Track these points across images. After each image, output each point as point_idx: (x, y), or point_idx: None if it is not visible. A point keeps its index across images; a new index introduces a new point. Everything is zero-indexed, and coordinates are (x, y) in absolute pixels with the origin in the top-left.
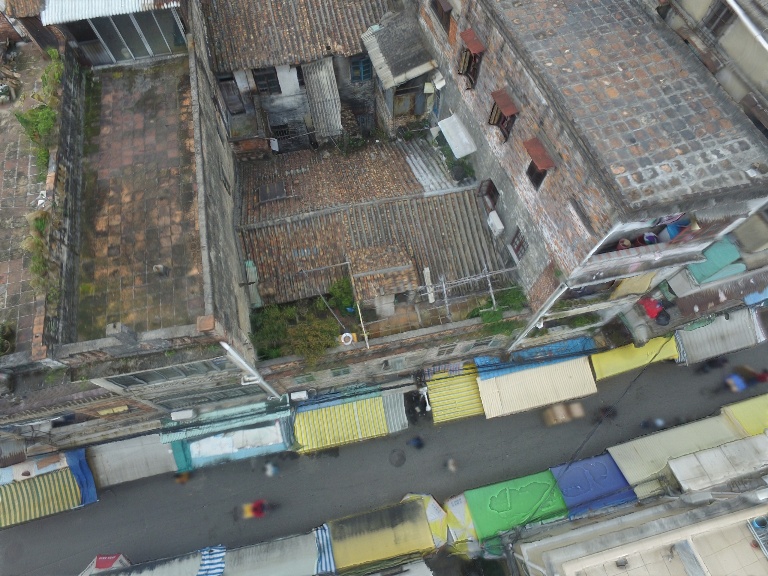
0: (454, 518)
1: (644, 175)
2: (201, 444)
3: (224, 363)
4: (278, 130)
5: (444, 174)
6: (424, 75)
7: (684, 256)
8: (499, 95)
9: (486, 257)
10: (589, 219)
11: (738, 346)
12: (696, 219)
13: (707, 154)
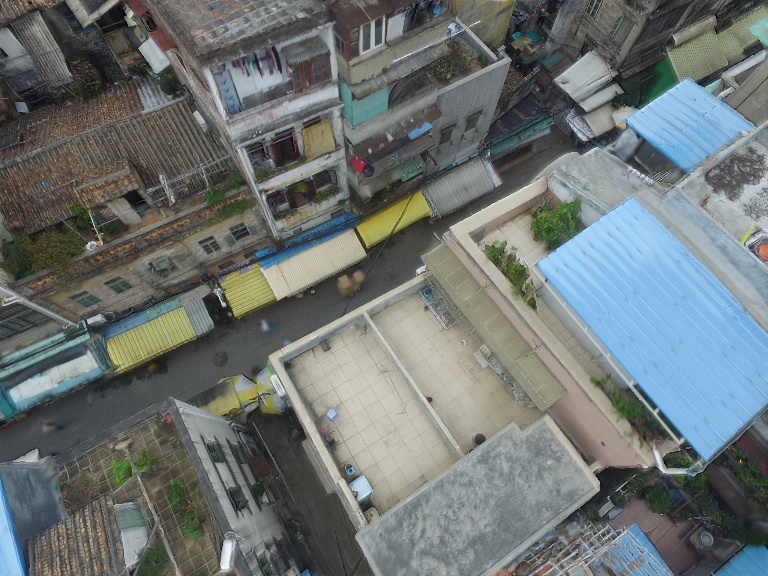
0: (261, 385)
1: (217, 32)
2: (20, 388)
3: None
4: (27, 95)
5: (164, 94)
6: (115, 8)
7: (326, 105)
8: (131, 1)
9: (213, 155)
10: (201, 80)
11: (480, 193)
12: (288, 64)
13: (268, 8)
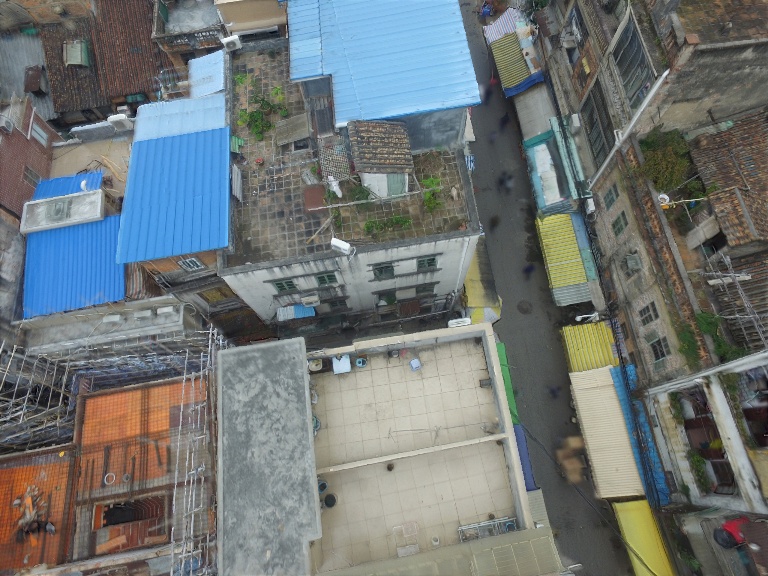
0: None
1: None
2: (545, 151)
3: (638, 103)
4: None
5: None
6: None
7: None
8: None
9: None
10: None
11: None
12: None
13: None
